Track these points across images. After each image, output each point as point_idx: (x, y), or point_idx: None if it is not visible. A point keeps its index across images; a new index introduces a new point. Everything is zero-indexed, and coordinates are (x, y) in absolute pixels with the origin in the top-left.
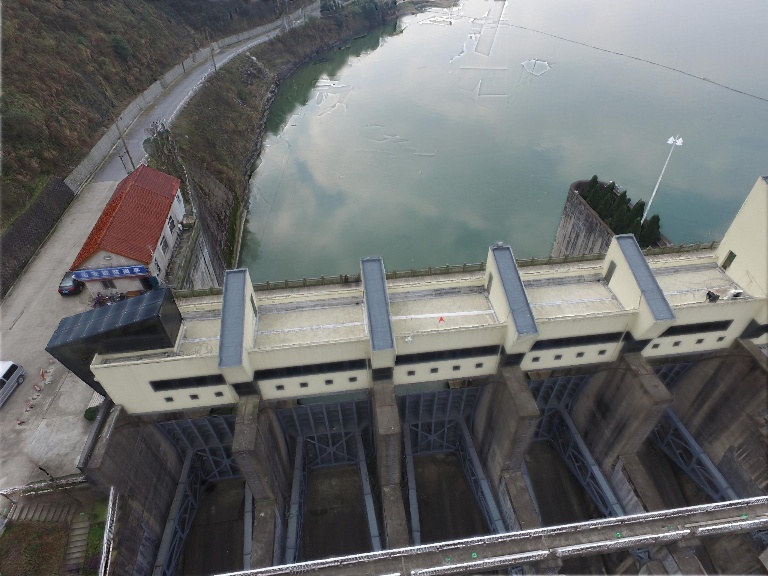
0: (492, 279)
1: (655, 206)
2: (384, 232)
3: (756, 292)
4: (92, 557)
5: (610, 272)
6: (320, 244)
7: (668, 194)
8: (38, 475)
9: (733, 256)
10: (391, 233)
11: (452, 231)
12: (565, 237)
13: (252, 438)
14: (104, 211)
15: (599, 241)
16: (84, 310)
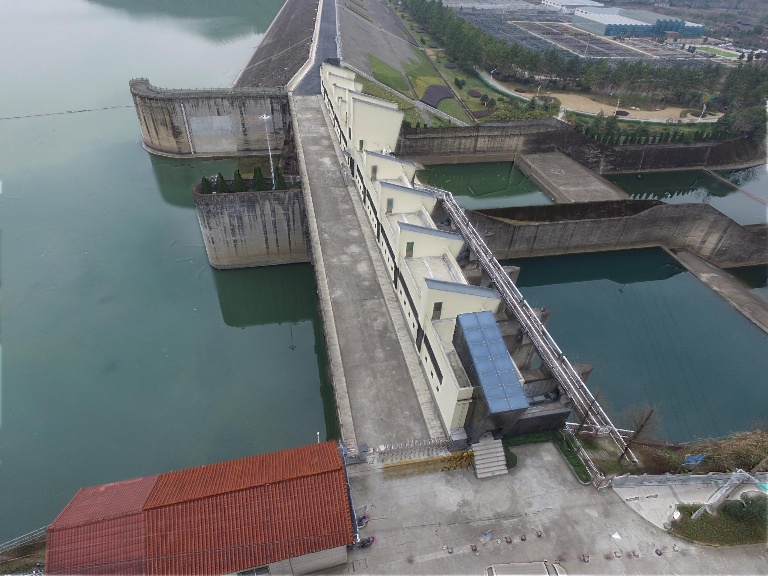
0: (393, 200)
1: (150, 204)
2: (89, 387)
3: (383, 147)
4: (589, 438)
5: (374, 172)
6: (82, 461)
7: (137, 194)
8: (572, 483)
9: (362, 142)
10: (95, 380)
11: (120, 326)
12: (226, 229)
13: (506, 326)
14: (182, 572)
15: (267, 203)
16: (367, 569)
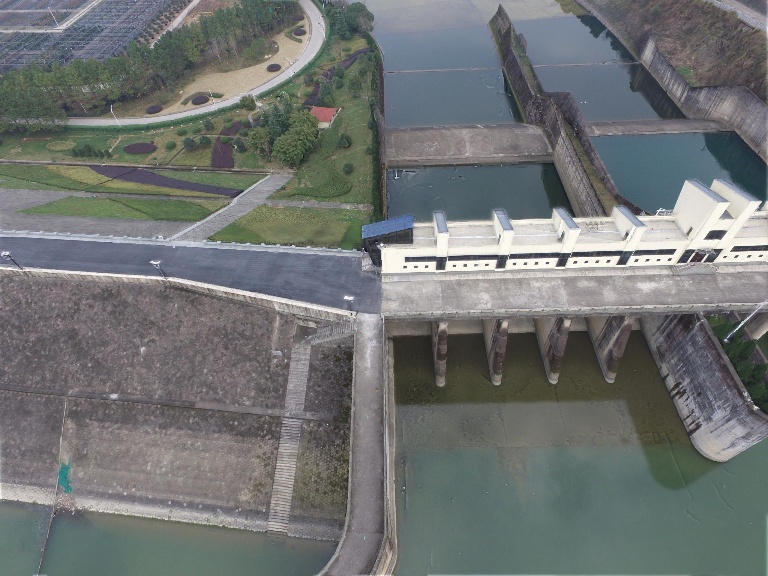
0: None
1: None
2: None
3: None
4: None
5: None
6: None
7: None
8: None
9: None
10: None
11: None
12: None
13: None
14: None
15: None
16: None
